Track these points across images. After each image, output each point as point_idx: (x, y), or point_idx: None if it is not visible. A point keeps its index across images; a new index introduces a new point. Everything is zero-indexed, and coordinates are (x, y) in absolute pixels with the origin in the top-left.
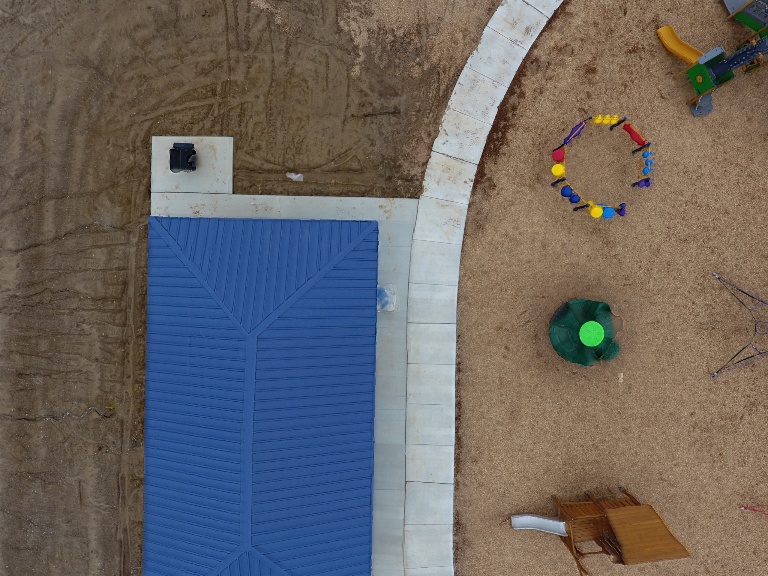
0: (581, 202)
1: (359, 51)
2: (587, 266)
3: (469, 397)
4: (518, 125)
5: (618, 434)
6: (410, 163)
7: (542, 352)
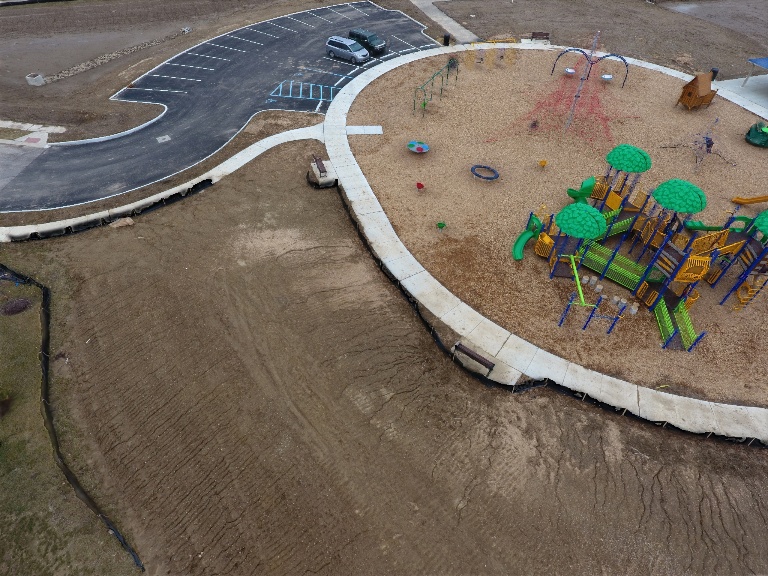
0: None
1: None
2: None
3: None
4: None
5: None
6: None
7: None
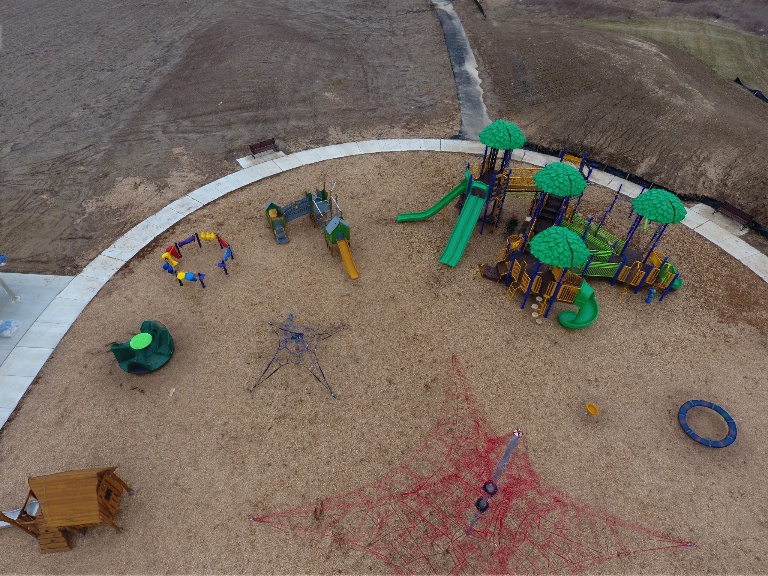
0: (174, 271)
1: (86, 214)
2: (176, 316)
3: (31, 403)
4: (164, 245)
5: (151, 439)
6: (81, 259)
7: (114, 371)
